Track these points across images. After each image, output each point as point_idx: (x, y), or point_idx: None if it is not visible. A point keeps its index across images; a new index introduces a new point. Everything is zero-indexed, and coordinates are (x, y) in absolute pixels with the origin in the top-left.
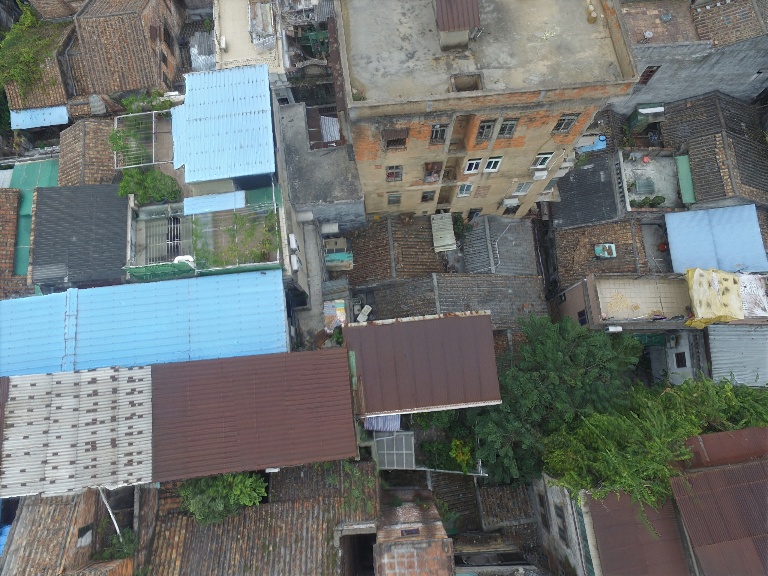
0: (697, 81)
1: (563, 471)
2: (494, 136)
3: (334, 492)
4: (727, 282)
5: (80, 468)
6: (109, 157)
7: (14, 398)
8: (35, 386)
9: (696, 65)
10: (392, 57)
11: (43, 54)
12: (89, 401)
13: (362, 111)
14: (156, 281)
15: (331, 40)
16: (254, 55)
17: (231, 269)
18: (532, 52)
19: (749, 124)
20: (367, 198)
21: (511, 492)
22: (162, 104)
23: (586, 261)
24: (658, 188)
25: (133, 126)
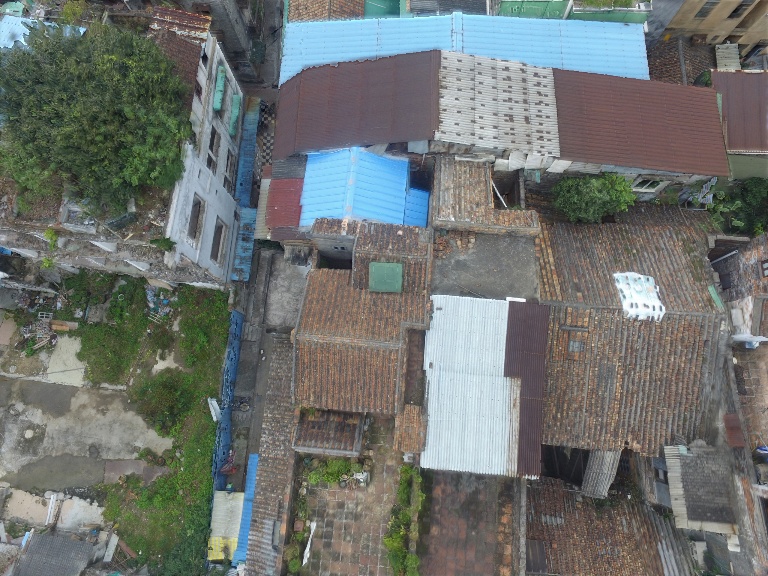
0: None
1: None
2: None
3: (679, 225)
4: None
5: (502, 133)
6: None
7: (445, 67)
8: (461, 62)
9: None
10: None
11: None
12: (504, 84)
13: None
14: None
15: None
16: None
17: (602, 14)
18: None
19: None
20: None
21: None
22: None
23: None
24: None
25: None
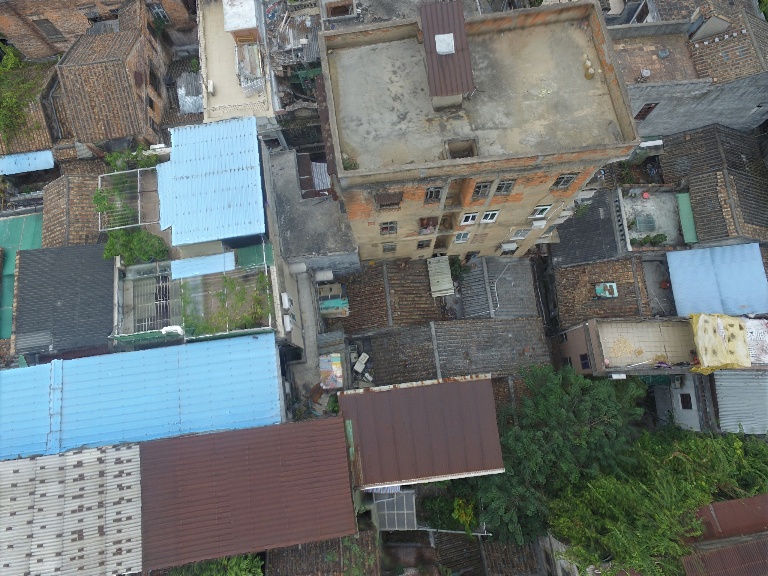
0: (696, 115)
1: (570, 538)
2: (491, 194)
3: (333, 566)
4: (733, 328)
5: (66, 560)
6: (94, 213)
7: None
8: (18, 473)
9: (695, 101)
10: (383, 119)
11: (26, 98)
12: (75, 486)
13: (353, 179)
14: (145, 345)
15: (320, 98)
16: (242, 98)
17: (222, 335)
18: (528, 111)
19: (749, 155)
20: (361, 248)
21: (516, 546)
22: (147, 159)
23: (587, 300)
24: (659, 225)
25: (117, 185)
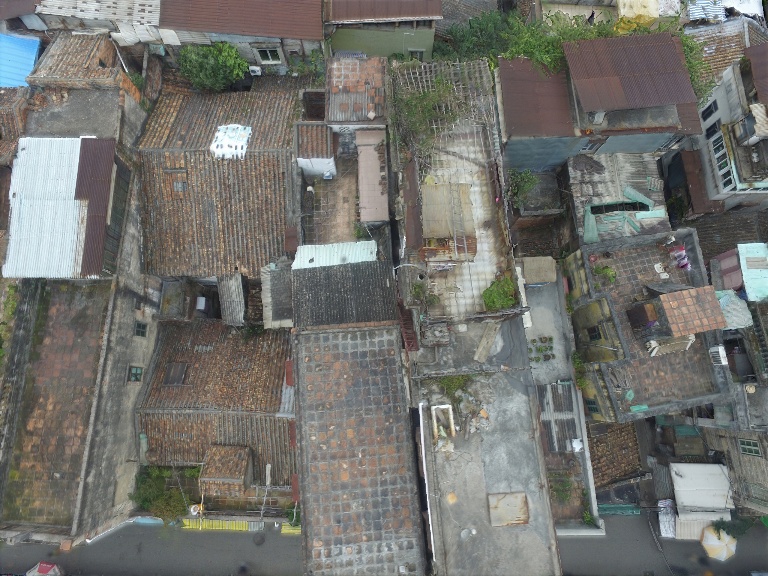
0: None
1: None
2: None
3: None
4: None
5: (104, 6)
6: None
7: None
8: None
9: None
10: None
11: None
12: None
13: None
14: None
15: None
16: None
17: None
18: None
19: None
20: None
21: None
22: None
23: None
24: None
25: None
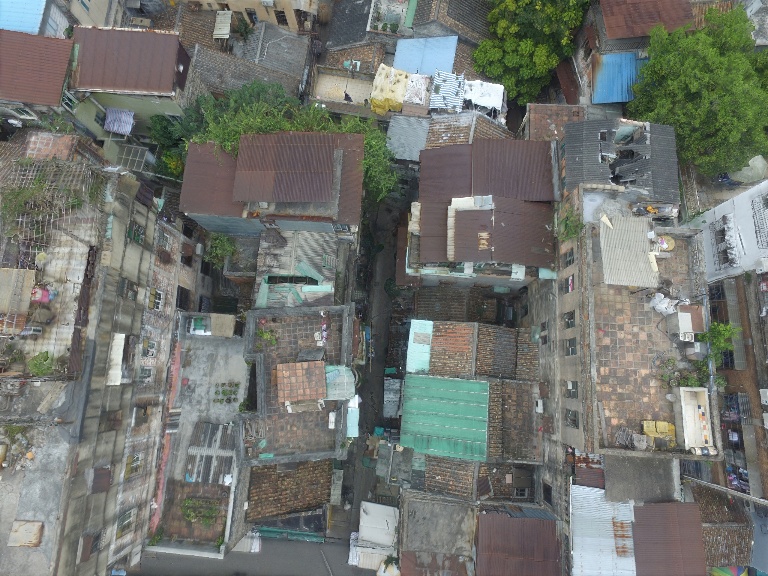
0: None
1: None
2: None
3: None
4: (400, 76)
5: None
6: None
7: None
8: None
9: None
10: None
11: None
12: None
13: None
14: None
15: None
16: None
17: None
18: None
19: None
20: None
21: None
22: None
23: None
24: (403, 23)
25: None
